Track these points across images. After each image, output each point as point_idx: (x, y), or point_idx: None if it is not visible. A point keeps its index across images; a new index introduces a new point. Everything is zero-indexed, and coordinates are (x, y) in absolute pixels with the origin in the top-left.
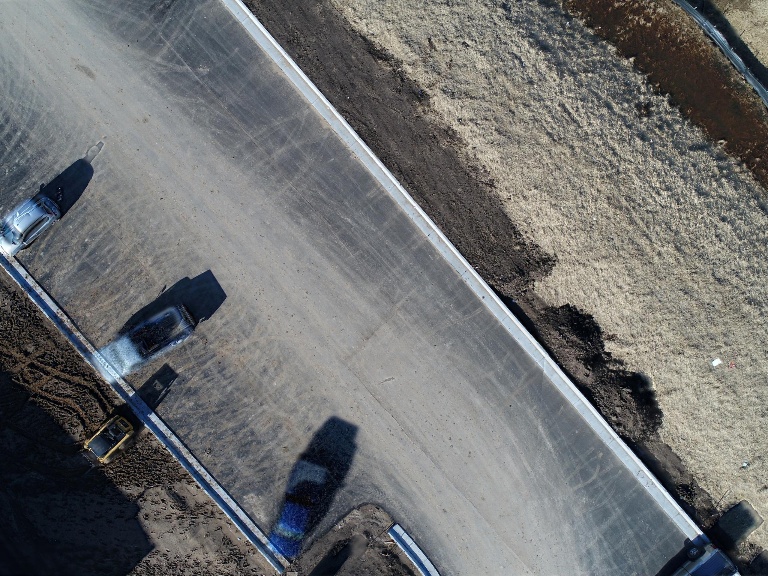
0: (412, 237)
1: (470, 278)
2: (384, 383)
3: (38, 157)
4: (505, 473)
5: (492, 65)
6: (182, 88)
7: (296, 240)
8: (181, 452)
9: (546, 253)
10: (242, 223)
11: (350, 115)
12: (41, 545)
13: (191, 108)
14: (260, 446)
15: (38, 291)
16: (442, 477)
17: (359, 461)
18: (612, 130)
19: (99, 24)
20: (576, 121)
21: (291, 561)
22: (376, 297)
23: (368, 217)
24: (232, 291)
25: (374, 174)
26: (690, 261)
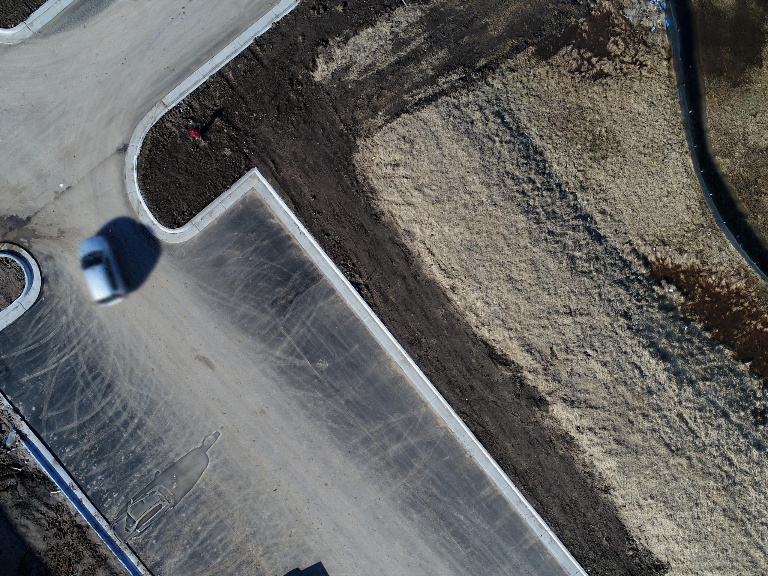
0: (524, 536)
1: None
2: None
3: (154, 444)
4: None
5: (612, 375)
6: (301, 382)
7: (408, 535)
8: None
9: (659, 560)
10: (355, 517)
11: (468, 416)
12: None
13: (309, 402)
14: None
15: None
16: None
17: None
18: (729, 440)
19: (221, 316)
20: (693, 431)
21: None
22: None
23: (481, 515)
24: None
25: (489, 474)
26: None
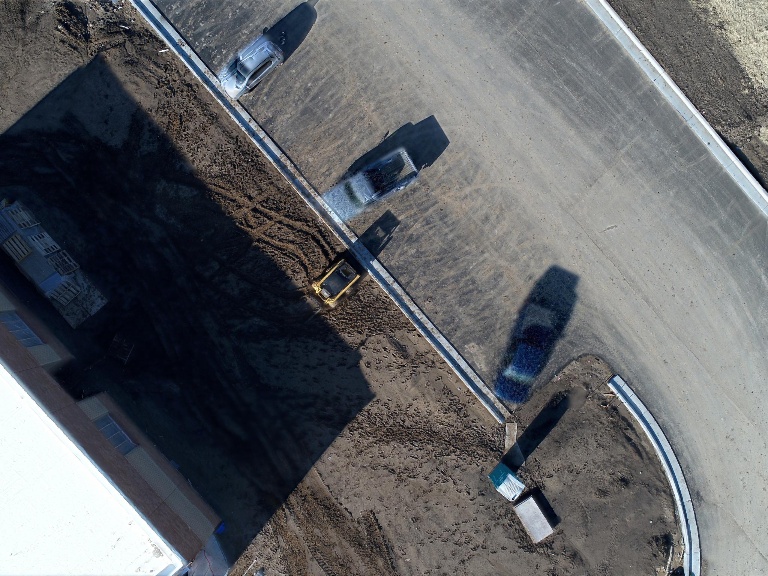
0: (638, 82)
1: (696, 124)
2: (606, 231)
3: (261, 0)
4: (727, 323)
5: None
6: None
7: (520, 85)
8: (403, 300)
9: None
10: (466, 67)
11: None
12: (263, 392)
13: None
14: (481, 295)
15: (261, 135)
16: (664, 327)
17: (580, 311)
18: None
19: None
20: None
21: (511, 412)
22: (600, 143)
23: (593, 62)
24: (455, 137)
25: (601, 17)
26: None
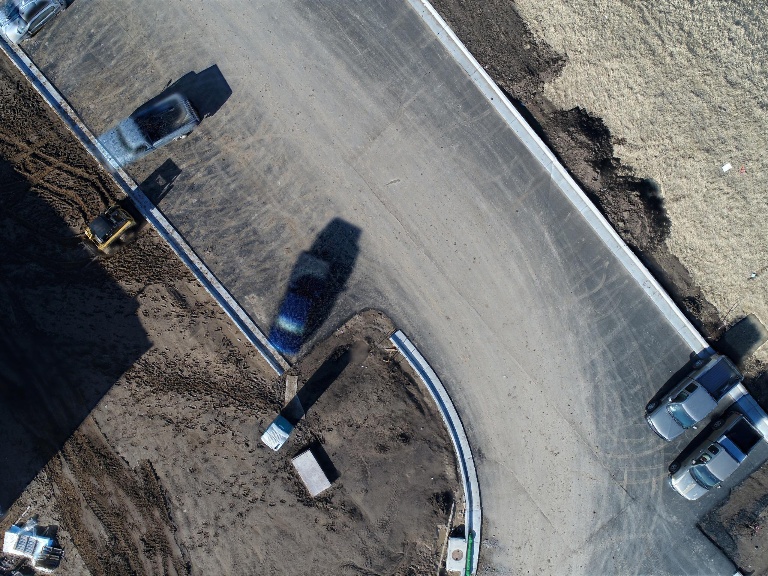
0: (421, 35)
1: (479, 79)
2: (389, 185)
3: None
4: (510, 280)
5: None
6: None
7: (304, 36)
8: (183, 249)
9: (556, 53)
10: (250, 17)
11: None
12: (39, 338)
13: None
14: (263, 246)
15: (42, 81)
16: (446, 283)
17: (362, 264)
18: None
19: None
20: None
21: (291, 364)
22: (383, 96)
23: (377, 14)
24: (238, 87)
25: None
26: (702, 63)
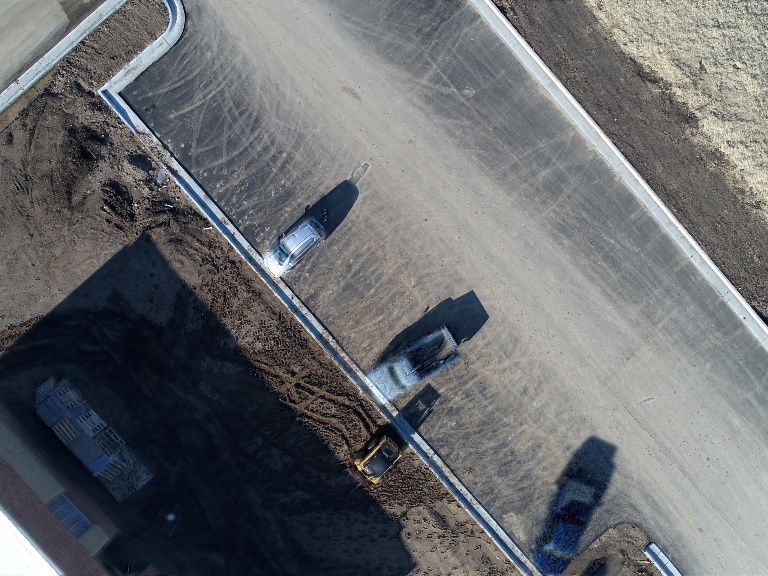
0: (675, 258)
1: (732, 299)
2: (643, 403)
3: (304, 178)
4: (762, 493)
5: (762, 87)
6: (448, 110)
7: (559, 261)
8: (443, 472)
9: None
10: (506, 244)
11: (617, 137)
12: (306, 564)
13: (457, 130)
14: (520, 466)
15: (304, 312)
16: (699, 496)
17: (617, 480)
18: None
19: (366, 46)
20: None
21: None
22: (637, 318)
23: (631, 238)
24: (494, 312)
25: (639, 196)
26: None
